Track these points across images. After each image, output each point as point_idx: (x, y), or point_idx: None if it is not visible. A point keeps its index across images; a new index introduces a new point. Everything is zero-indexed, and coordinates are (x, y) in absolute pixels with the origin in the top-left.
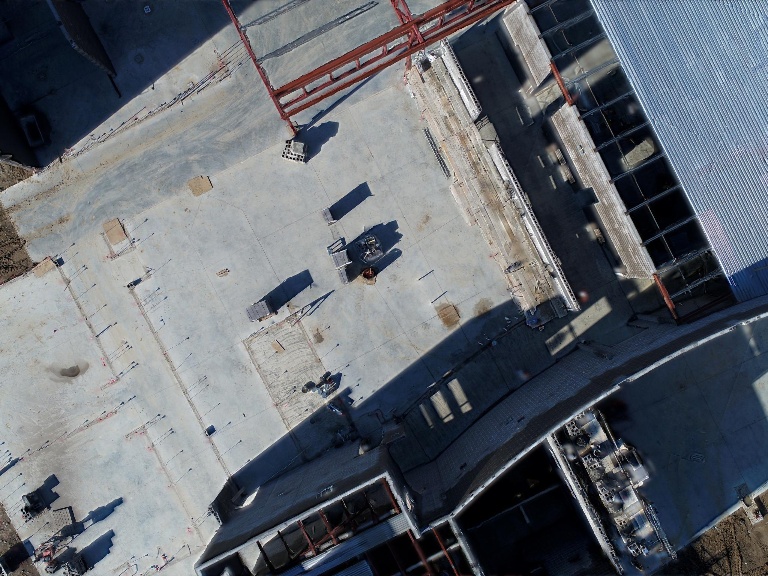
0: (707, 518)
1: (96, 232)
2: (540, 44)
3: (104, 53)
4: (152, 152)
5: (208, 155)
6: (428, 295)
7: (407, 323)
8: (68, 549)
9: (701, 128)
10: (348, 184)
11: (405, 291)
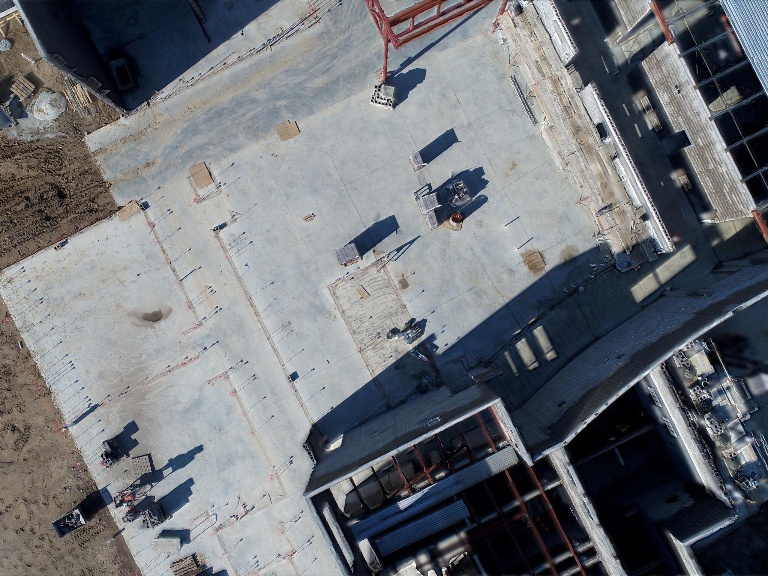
0: None
1: (182, 176)
2: None
3: None
4: (240, 97)
5: (296, 100)
6: (514, 241)
7: (493, 269)
8: (146, 498)
9: None
10: (435, 130)
11: (491, 237)
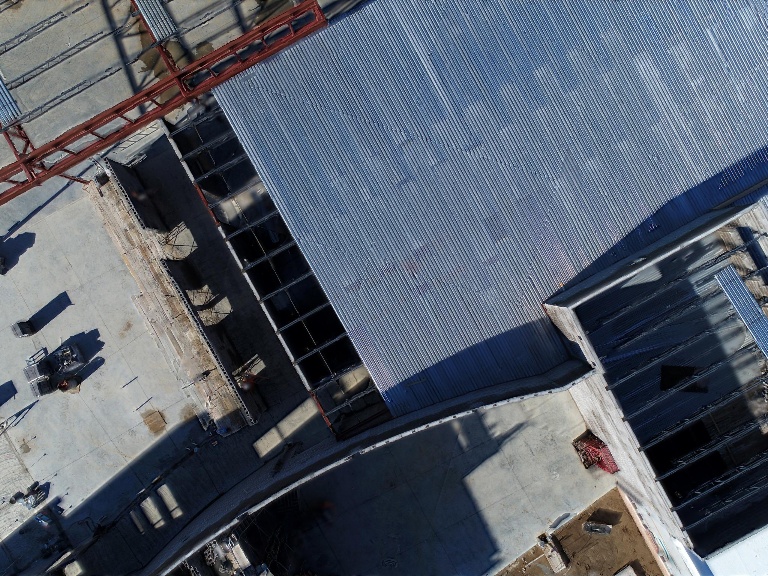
0: None
1: None
2: None
3: None
4: None
5: None
6: (133, 402)
7: (113, 430)
8: None
9: (348, 245)
10: (48, 294)
11: (110, 399)
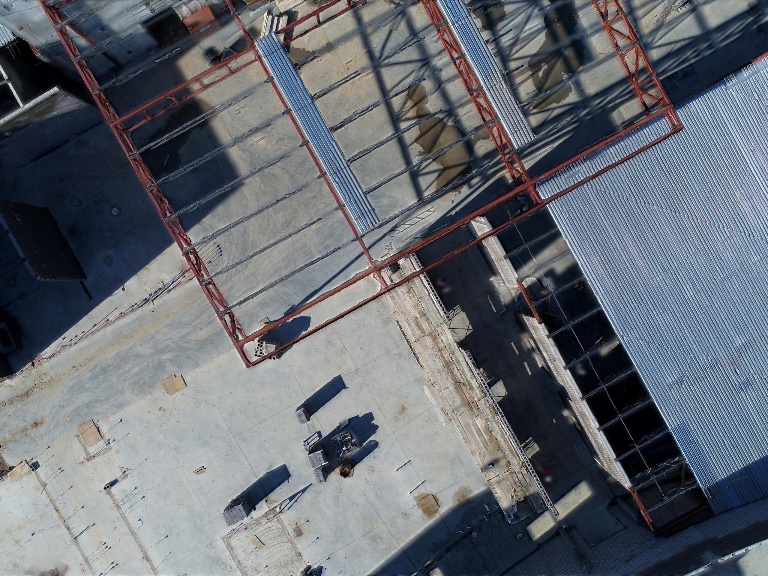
0: None
1: (71, 434)
2: (506, 263)
3: (73, 257)
4: (124, 353)
5: (181, 354)
6: (406, 485)
7: (386, 514)
8: None
9: (671, 342)
10: (322, 377)
11: (383, 482)
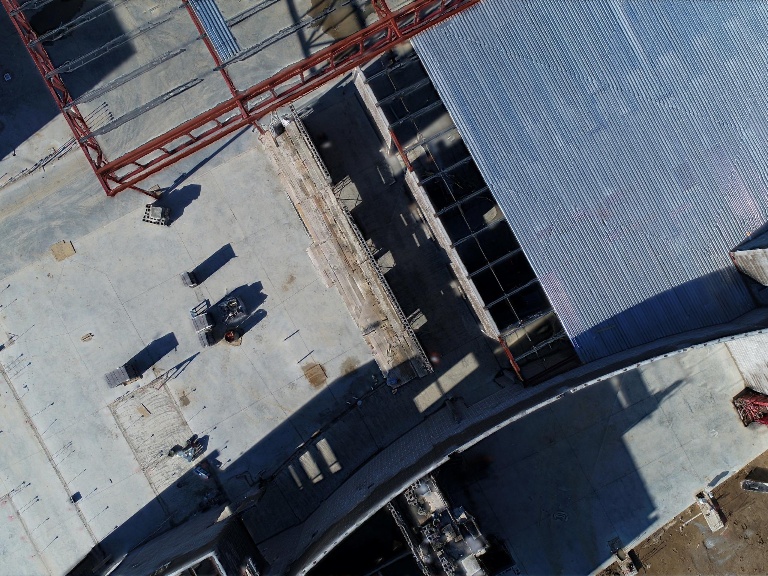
0: (581, 573)
1: None
2: (378, 112)
3: None
4: (14, 218)
5: (70, 220)
6: (294, 355)
7: (274, 384)
8: None
9: (539, 192)
10: (211, 246)
11: (271, 352)
